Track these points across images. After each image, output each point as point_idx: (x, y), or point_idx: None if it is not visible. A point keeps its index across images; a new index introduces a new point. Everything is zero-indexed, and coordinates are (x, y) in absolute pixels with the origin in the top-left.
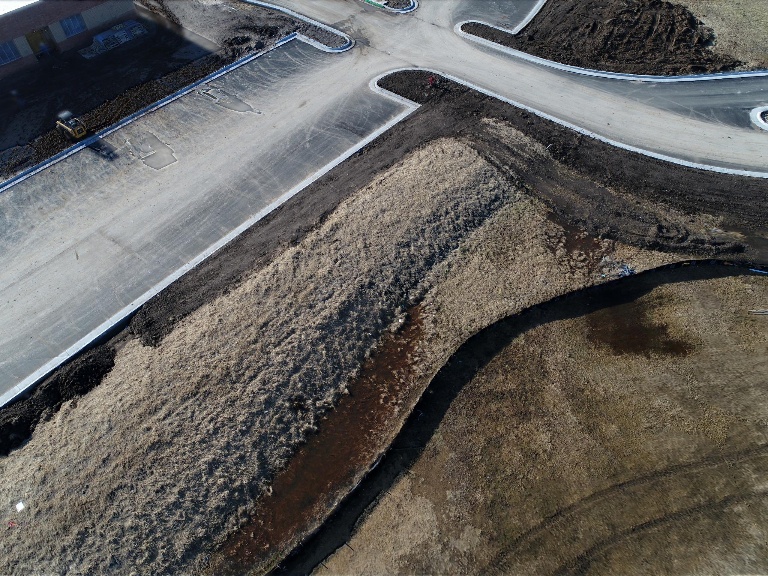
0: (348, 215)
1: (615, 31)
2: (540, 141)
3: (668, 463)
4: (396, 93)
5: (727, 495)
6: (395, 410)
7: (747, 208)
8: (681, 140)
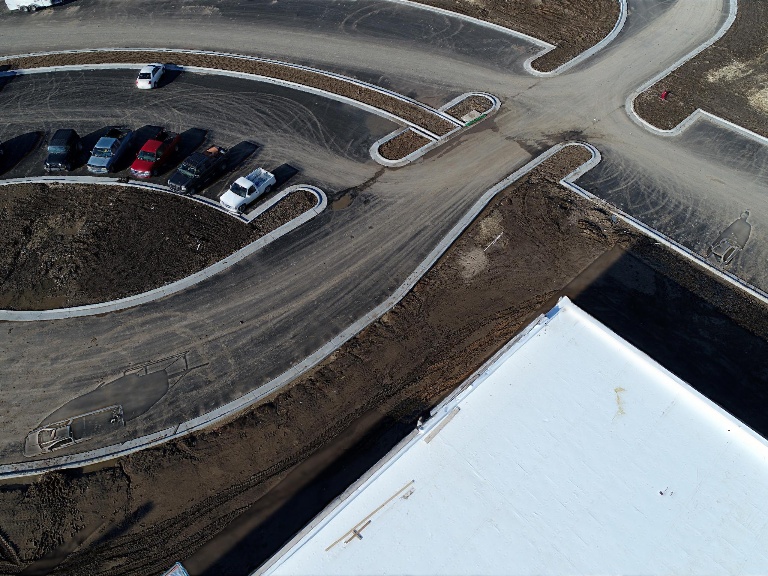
0: None
1: (556, 3)
2: (731, 62)
3: None
4: (682, 120)
5: None
6: None
7: (765, 12)
8: (703, 14)
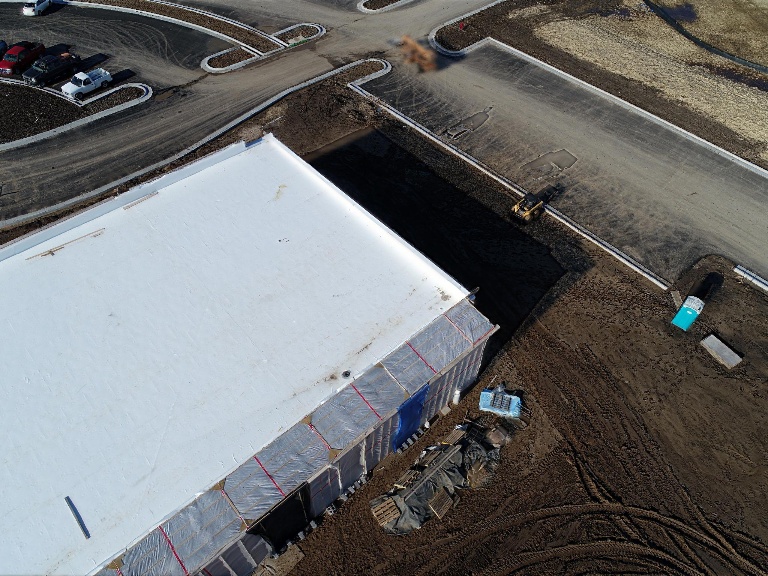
0: (629, 69)
1: None
2: (535, 4)
3: (752, 19)
4: (471, 44)
5: (761, 12)
6: (760, 75)
7: None
8: None
